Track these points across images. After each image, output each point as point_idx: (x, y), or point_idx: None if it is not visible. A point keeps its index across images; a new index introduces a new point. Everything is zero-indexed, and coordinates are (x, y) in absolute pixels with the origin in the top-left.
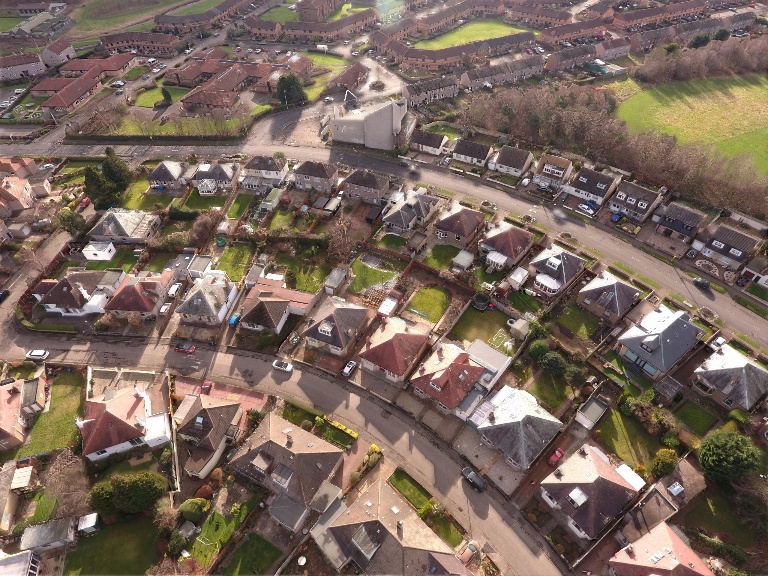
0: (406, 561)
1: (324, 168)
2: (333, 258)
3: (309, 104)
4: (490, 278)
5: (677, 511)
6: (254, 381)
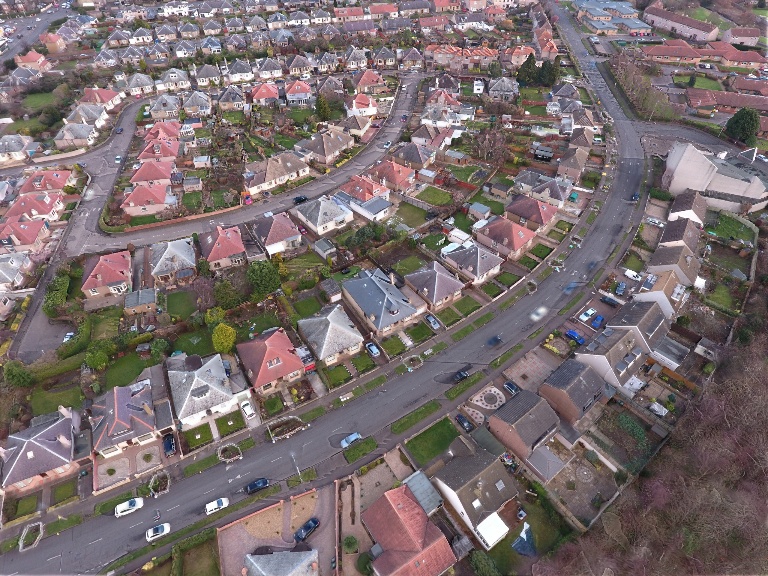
0: (264, 162)
1: (579, 136)
2: (480, 158)
3: (741, 148)
4: (463, 227)
5: (248, 258)
6: (380, 139)
